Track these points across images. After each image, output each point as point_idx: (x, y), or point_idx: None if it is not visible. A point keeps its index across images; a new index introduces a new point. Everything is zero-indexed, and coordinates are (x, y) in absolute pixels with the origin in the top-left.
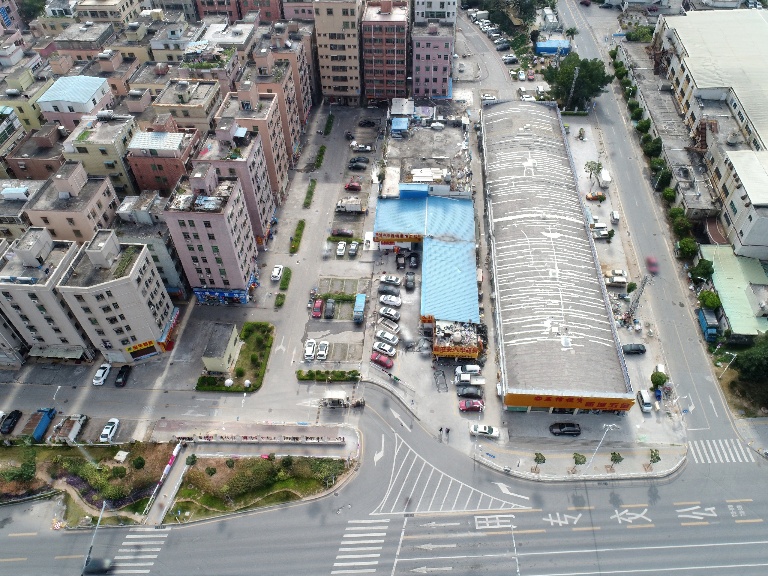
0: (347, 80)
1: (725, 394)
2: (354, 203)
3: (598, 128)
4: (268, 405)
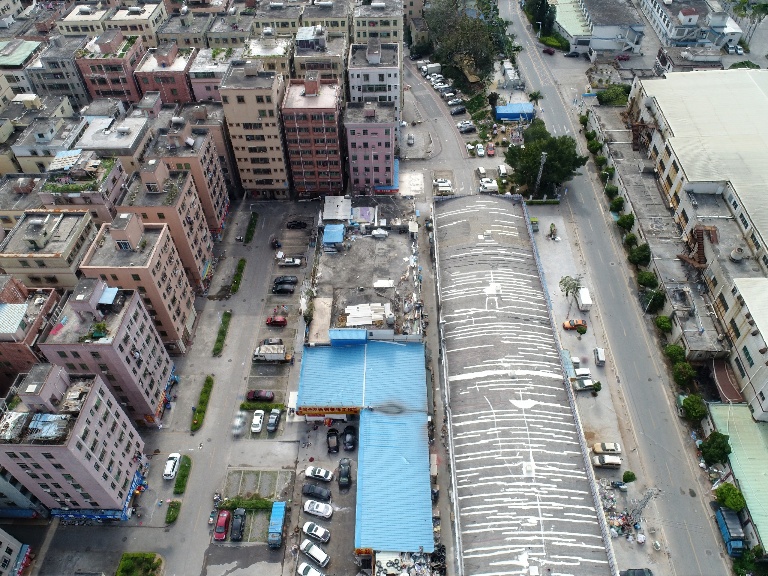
0: (271, 173)
1: None
2: (275, 352)
3: (572, 221)
4: None
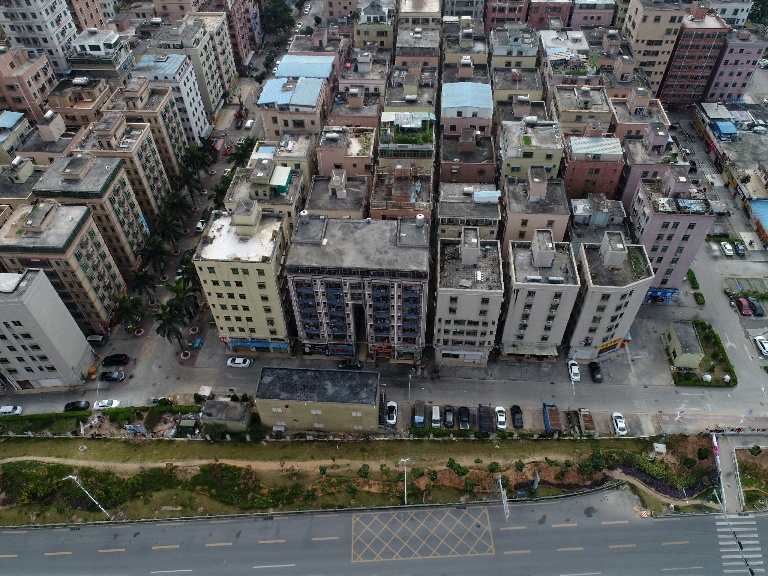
0: None
1: None
2: (719, 205)
3: None
4: (756, 399)
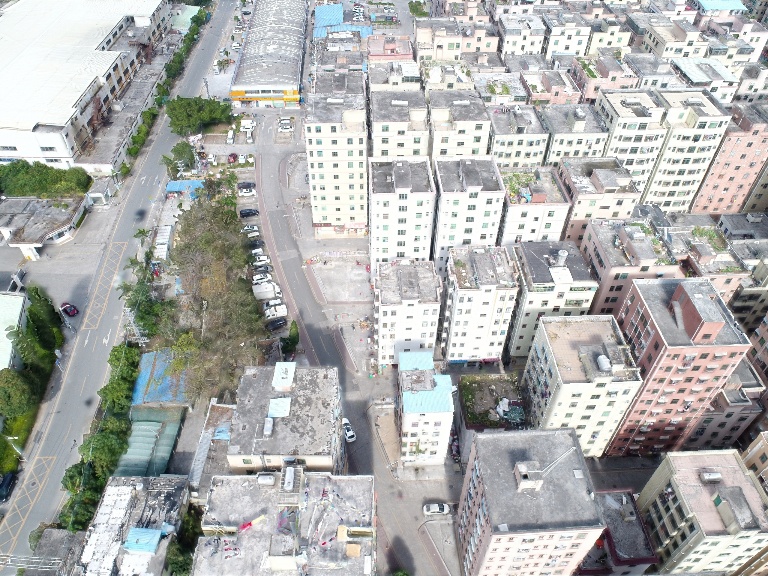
0: None
1: (215, 6)
2: None
3: None
4: (403, 0)
